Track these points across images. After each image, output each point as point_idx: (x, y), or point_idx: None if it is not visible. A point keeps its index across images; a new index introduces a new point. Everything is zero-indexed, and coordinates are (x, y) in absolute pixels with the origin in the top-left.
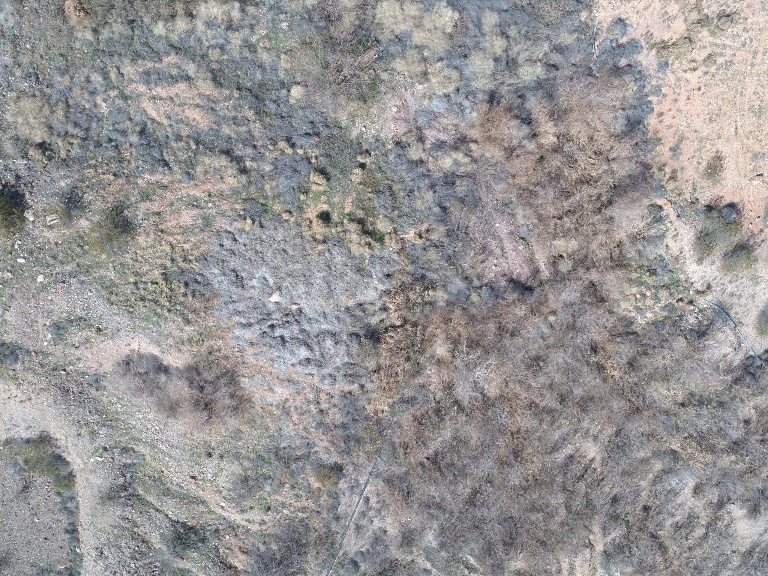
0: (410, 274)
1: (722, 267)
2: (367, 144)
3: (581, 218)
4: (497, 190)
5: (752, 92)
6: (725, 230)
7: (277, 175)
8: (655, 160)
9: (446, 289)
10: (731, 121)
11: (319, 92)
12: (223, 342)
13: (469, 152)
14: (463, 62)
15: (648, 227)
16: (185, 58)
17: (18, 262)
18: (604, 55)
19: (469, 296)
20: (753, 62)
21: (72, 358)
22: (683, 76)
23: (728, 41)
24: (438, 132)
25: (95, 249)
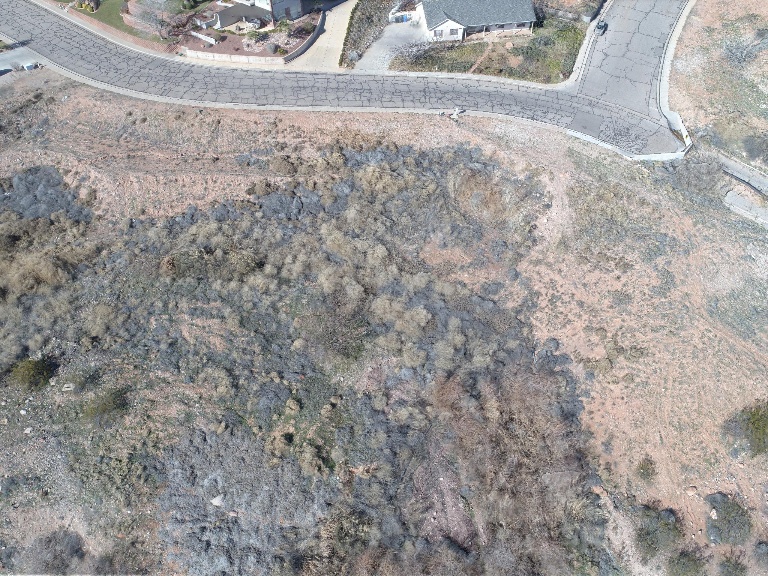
0: (350, 506)
1: (670, 575)
2: (342, 391)
3: (519, 486)
4: (445, 448)
5: (670, 410)
6: (664, 530)
7: (261, 395)
8: (589, 451)
9: (381, 527)
10: (655, 430)
11: (315, 347)
12: (150, 535)
13: (425, 412)
14: (430, 347)
15: (585, 509)
16: (226, 305)
17: (20, 413)
18: (541, 359)
19: (403, 543)
20: (665, 386)
21: (4, 520)
22: (607, 386)
23: (642, 367)
24: (402, 393)
25: (87, 418)
